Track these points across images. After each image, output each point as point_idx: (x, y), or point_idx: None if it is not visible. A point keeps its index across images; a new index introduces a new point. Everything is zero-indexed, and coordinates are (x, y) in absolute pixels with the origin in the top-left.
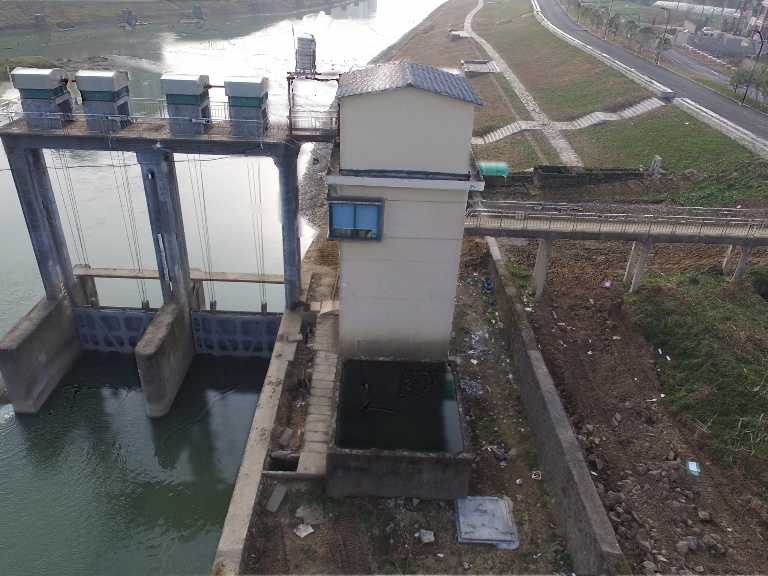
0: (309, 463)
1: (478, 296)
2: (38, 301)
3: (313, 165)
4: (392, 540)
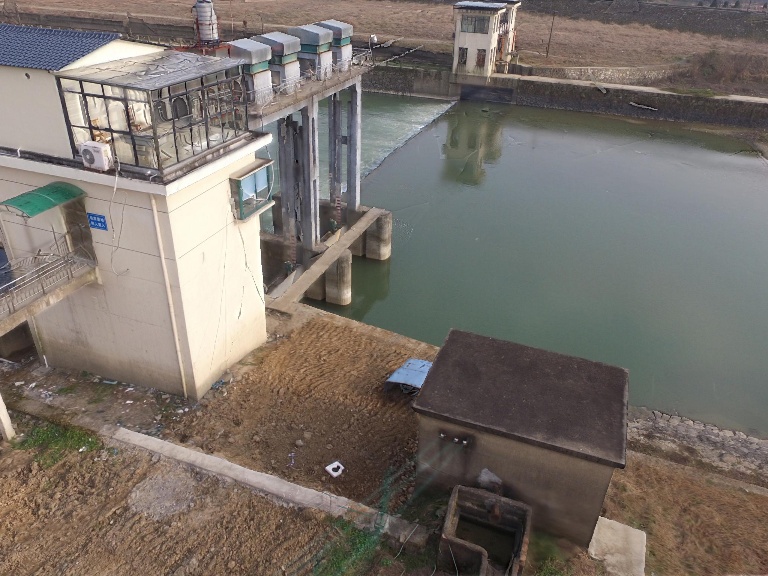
0: None
1: None
2: None
3: None
4: None
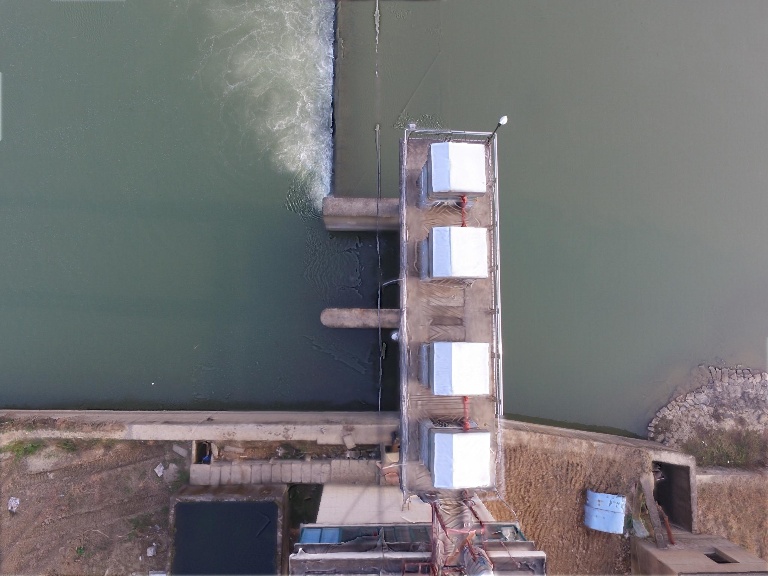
0: (199, 472)
1: None
2: None
3: None
4: (151, 527)
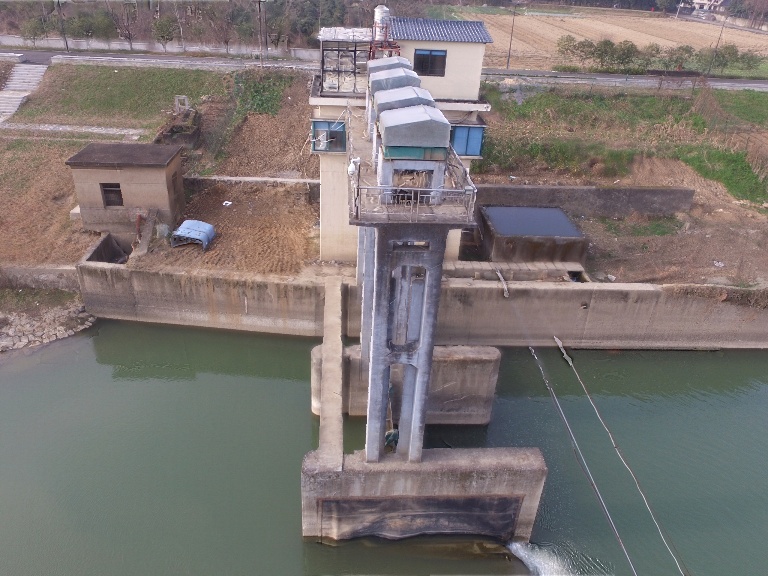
0: (575, 267)
1: None
2: (428, 470)
3: None
4: None
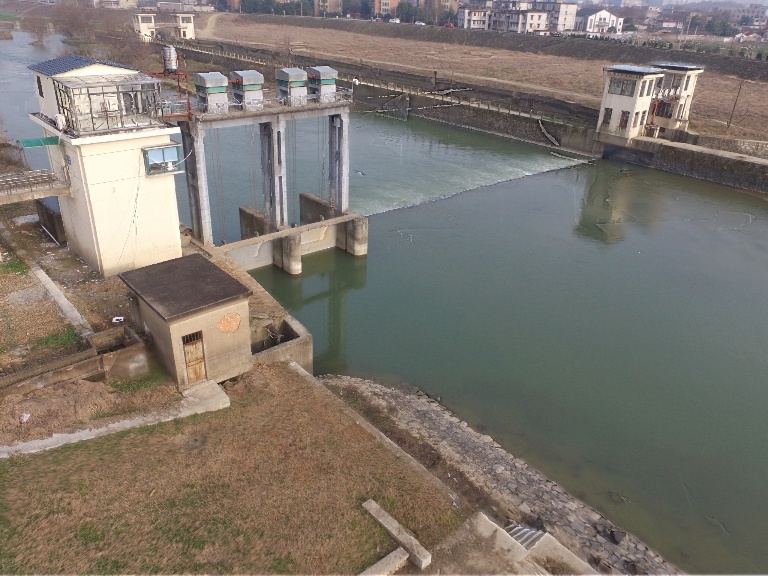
0: None
1: (57, 277)
2: None
3: (595, 519)
4: None
